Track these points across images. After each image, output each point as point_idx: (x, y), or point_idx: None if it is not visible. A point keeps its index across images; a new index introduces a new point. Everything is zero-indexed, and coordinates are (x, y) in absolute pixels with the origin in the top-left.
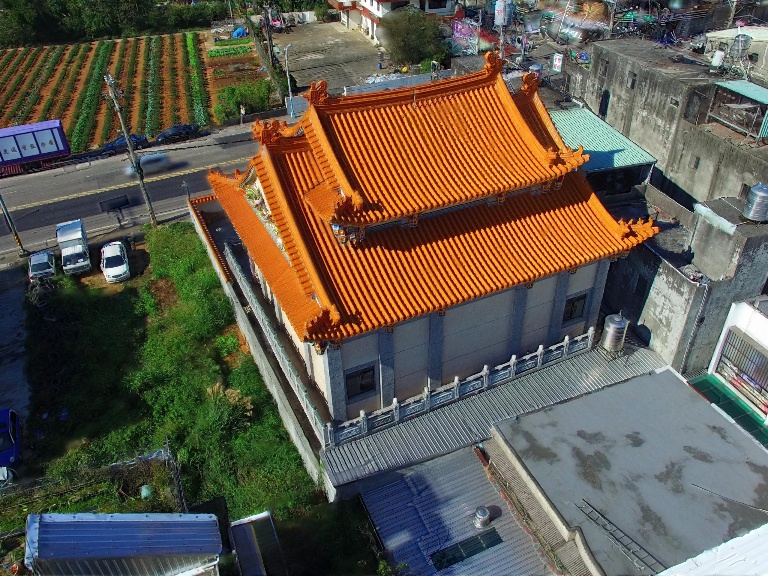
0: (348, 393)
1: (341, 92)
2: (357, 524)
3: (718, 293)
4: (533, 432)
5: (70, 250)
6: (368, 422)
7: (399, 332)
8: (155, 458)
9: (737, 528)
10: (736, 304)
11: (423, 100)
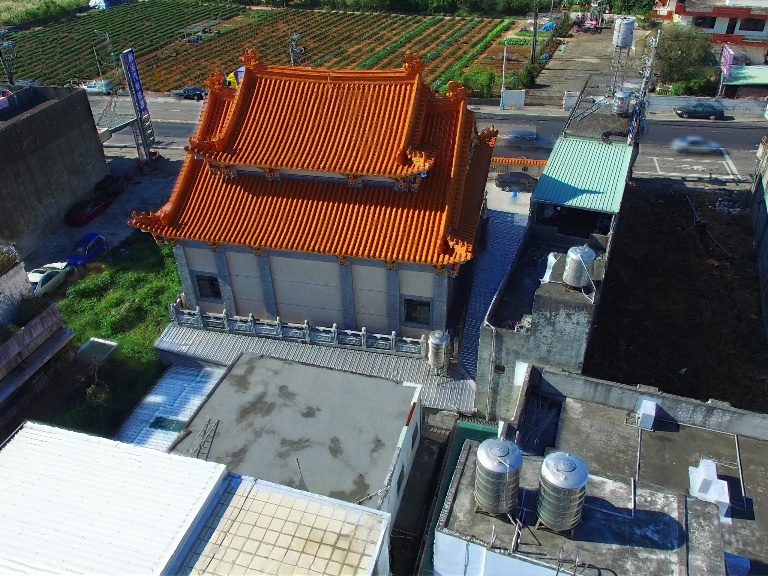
0: (201, 292)
1: (562, 96)
2: (148, 378)
3: (514, 345)
4: (257, 369)
5: None
6: (203, 318)
7: (234, 258)
8: (2, 249)
9: None
10: (518, 361)
11: (341, 83)
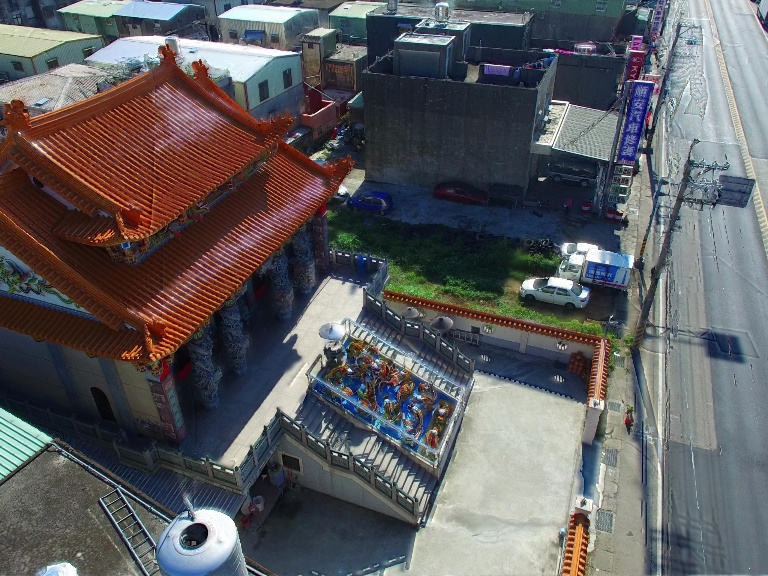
0: None
1: None
2: None
3: None
4: None
5: (578, 257)
6: None
7: None
8: None
9: None
10: None
11: None
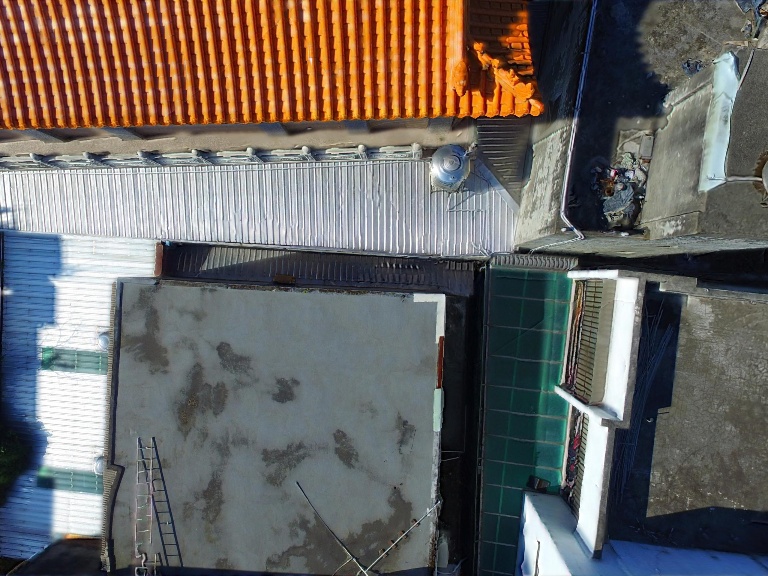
0: None
1: None
2: None
3: None
4: (162, 315)
5: None
6: (1, 164)
7: None
8: None
9: (297, 554)
10: (619, 276)
11: None
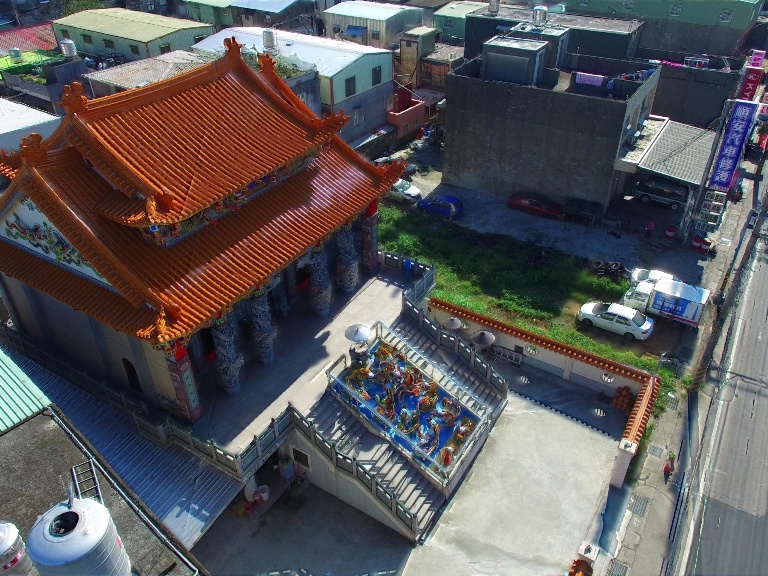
0: None
1: None
2: None
3: None
4: None
5: (647, 285)
6: None
7: None
8: None
9: None
10: None
11: None
